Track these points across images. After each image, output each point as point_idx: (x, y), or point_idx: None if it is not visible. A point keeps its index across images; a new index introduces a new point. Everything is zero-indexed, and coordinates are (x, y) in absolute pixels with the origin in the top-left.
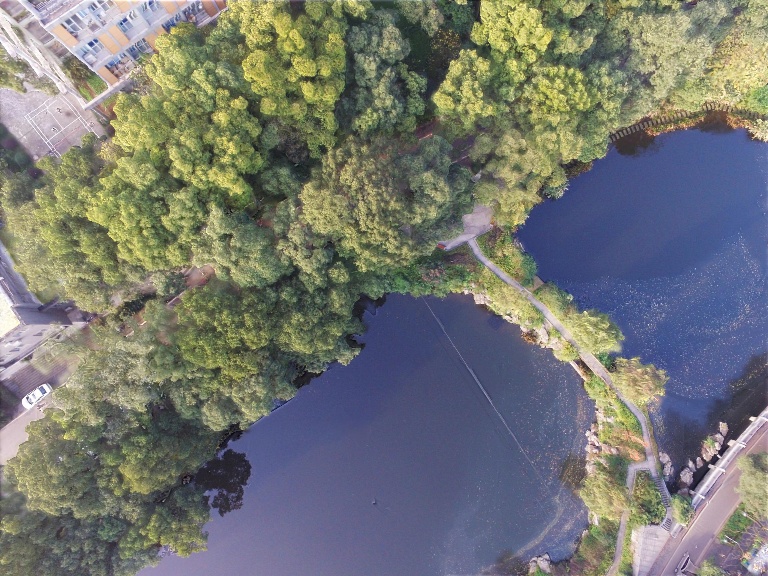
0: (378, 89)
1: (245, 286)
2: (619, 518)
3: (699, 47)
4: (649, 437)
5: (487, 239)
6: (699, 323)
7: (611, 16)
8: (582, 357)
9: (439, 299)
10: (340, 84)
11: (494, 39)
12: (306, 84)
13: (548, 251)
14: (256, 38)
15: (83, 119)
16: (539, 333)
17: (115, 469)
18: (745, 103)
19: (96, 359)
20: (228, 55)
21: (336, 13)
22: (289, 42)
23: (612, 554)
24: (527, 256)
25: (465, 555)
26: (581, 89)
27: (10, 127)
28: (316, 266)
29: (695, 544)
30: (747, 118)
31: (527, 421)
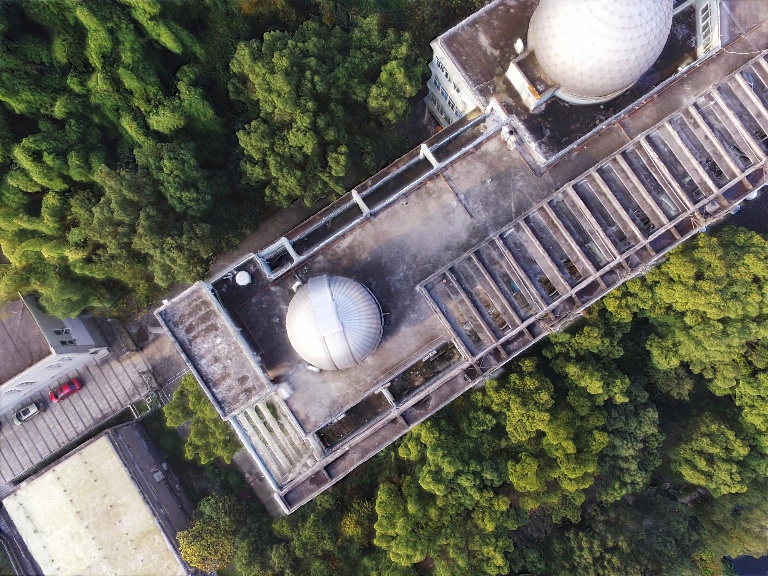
0: (629, 466)
1: None
2: None
3: None
4: None
5: None
6: None
7: None
8: None
9: None
10: (598, 473)
11: (752, 419)
12: (571, 484)
13: None
14: (524, 439)
15: None
16: None
17: None
18: None
19: None
20: (491, 451)
21: (599, 403)
22: (561, 450)
23: None
24: (728, 565)
25: None
26: None
27: None
28: None
29: None
30: None
31: None
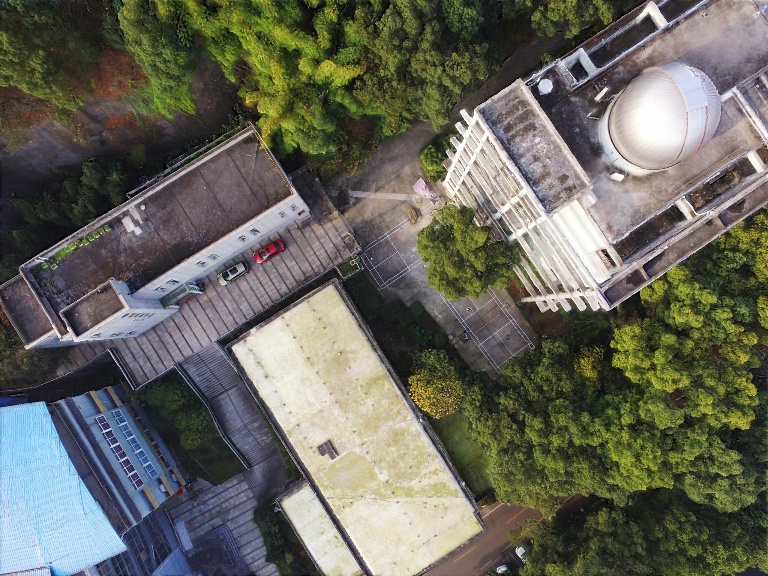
0: None
1: (725, 512)
2: None
3: None
4: None
5: None
6: None
7: None
8: None
9: None
10: None
11: None
12: None
13: None
14: None
15: (498, 300)
16: None
17: None
18: None
19: None
20: (740, 288)
21: None
22: None
23: None
24: None
25: None
26: None
27: (425, 305)
28: None
29: None
30: None
31: None
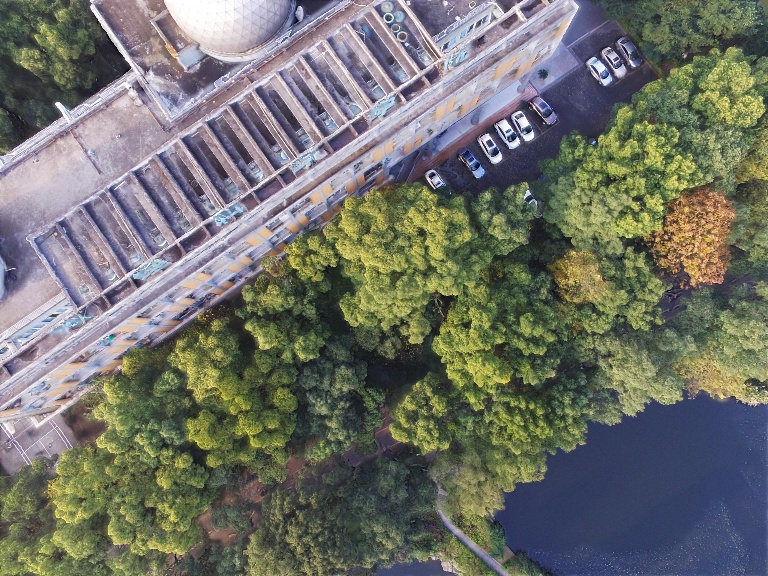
0: (331, 424)
1: None
2: None
3: None
4: None
5: None
6: None
7: (577, 332)
8: None
9: (405, 563)
10: (290, 430)
11: (451, 375)
12: (253, 441)
13: (519, 517)
14: (202, 397)
15: None
16: None
17: None
18: None
19: None
20: (174, 409)
21: (286, 361)
22: (235, 406)
23: None
24: (496, 530)
25: None
26: (542, 425)
27: None
28: None
29: None
30: None
31: None
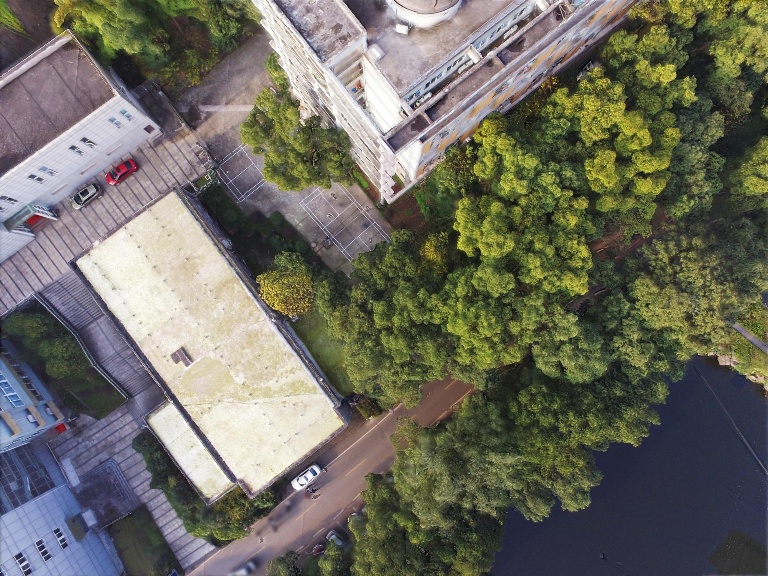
0: (696, 176)
1: (578, 383)
2: None
3: None
4: None
5: None
6: None
7: None
8: None
9: None
10: None
11: None
12: (647, 181)
13: None
14: (600, 137)
15: (358, 204)
16: None
17: (444, 564)
18: None
19: (442, 463)
20: (567, 154)
21: (668, 105)
22: None
23: None
24: None
25: None
26: None
27: (285, 215)
28: (647, 360)
29: None
30: None
31: None
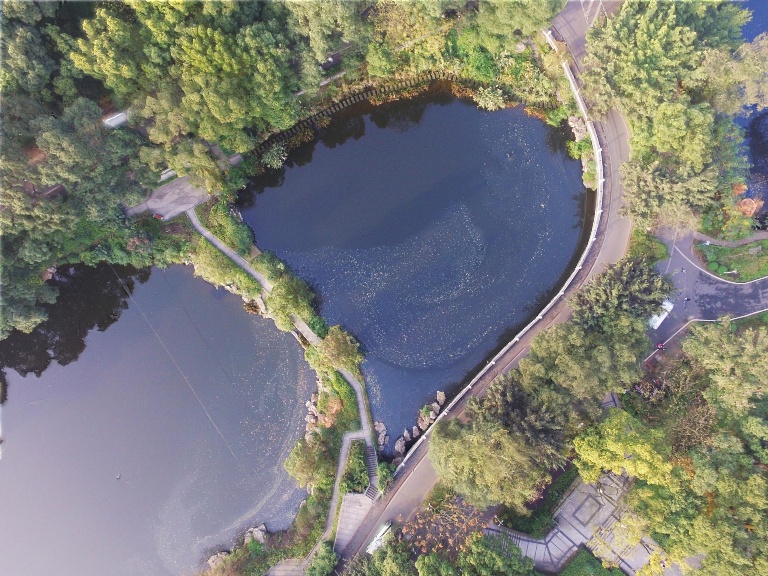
0: (9, 49)
1: None
2: (331, 487)
3: (333, 6)
4: (365, 406)
5: (203, 209)
6: (419, 292)
7: None
8: (296, 326)
9: (161, 270)
10: None
11: None
12: None
13: (269, 221)
14: None
15: None
16: (257, 303)
17: None
18: (466, 71)
19: None
20: None
21: None
22: None
23: (322, 524)
24: (240, 225)
25: (180, 526)
26: (219, 49)
27: None
28: None
29: (399, 512)
30: (469, 86)
31: (247, 392)
